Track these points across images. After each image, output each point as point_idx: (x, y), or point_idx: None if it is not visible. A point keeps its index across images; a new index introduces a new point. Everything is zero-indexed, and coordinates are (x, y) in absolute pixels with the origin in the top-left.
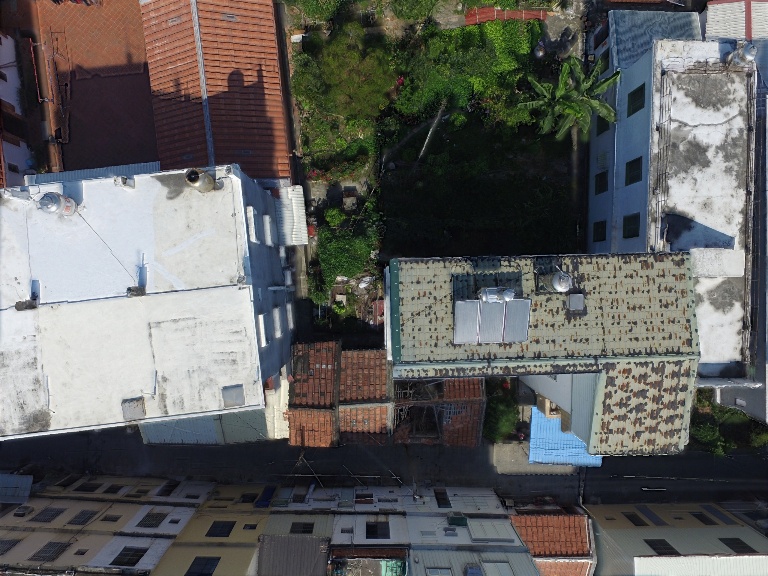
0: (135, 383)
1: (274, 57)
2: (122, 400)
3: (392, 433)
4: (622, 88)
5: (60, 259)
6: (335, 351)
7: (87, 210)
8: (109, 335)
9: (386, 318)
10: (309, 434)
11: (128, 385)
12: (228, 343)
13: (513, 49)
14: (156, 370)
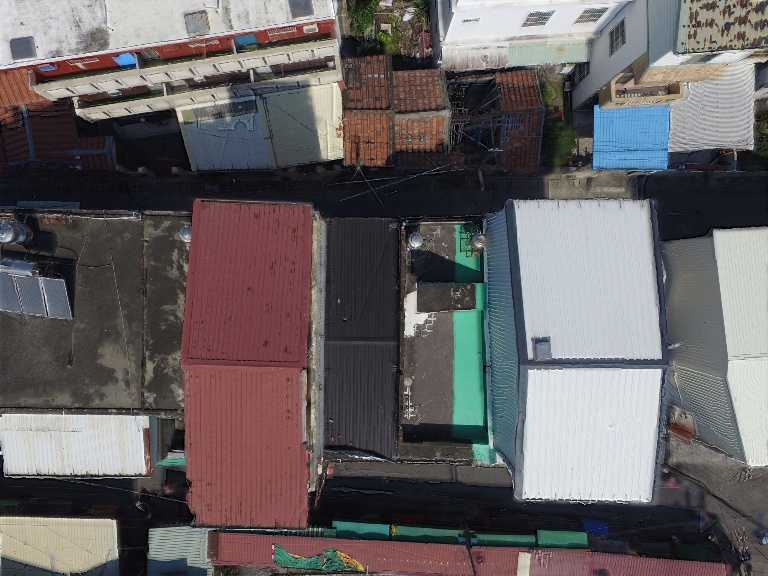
0: None
1: None
2: (184, 14)
3: (449, 152)
4: None
5: None
6: (386, 62)
7: None
8: None
9: None
10: (365, 148)
11: None
12: None
13: None
14: None
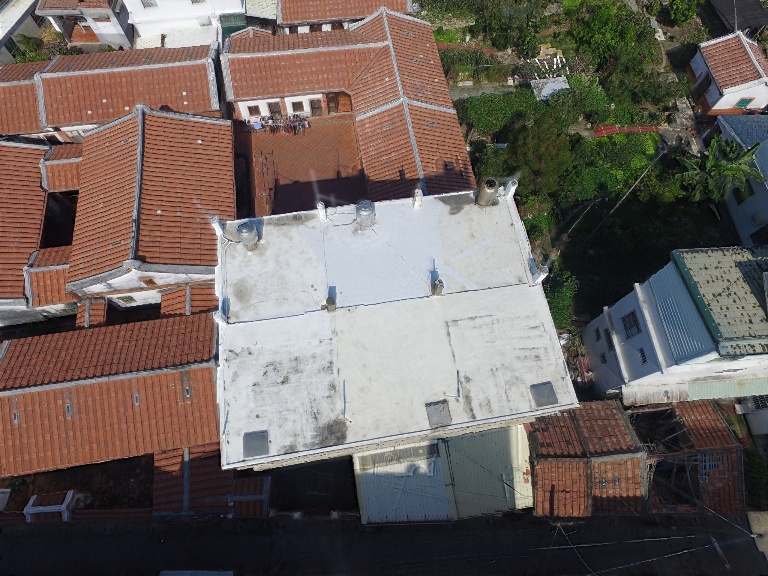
0: (437, 385)
1: (465, 151)
2: (425, 404)
3: (647, 496)
4: (759, 159)
5: (355, 267)
6: None
7: (379, 226)
8: (407, 335)
9: (649, 331)
10: (559, 497)
11: (430, 387)
12: (528, 339)
13: (640, 150)
14: (457, 370)
